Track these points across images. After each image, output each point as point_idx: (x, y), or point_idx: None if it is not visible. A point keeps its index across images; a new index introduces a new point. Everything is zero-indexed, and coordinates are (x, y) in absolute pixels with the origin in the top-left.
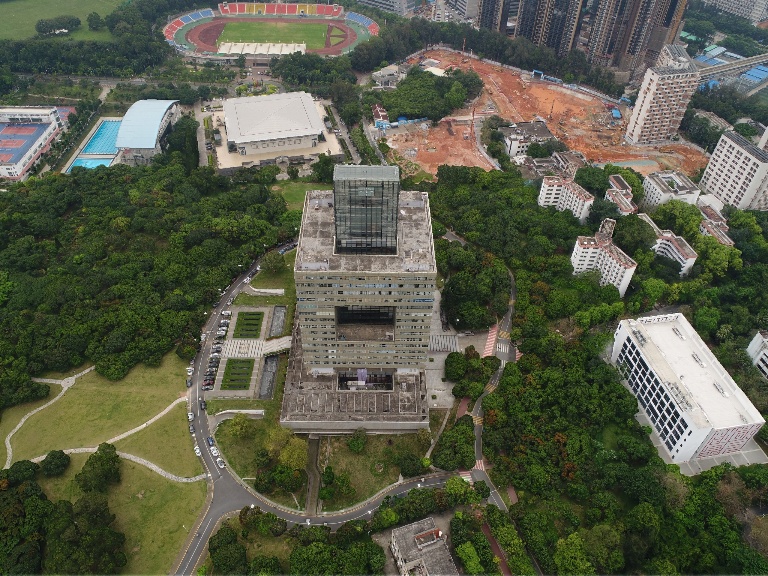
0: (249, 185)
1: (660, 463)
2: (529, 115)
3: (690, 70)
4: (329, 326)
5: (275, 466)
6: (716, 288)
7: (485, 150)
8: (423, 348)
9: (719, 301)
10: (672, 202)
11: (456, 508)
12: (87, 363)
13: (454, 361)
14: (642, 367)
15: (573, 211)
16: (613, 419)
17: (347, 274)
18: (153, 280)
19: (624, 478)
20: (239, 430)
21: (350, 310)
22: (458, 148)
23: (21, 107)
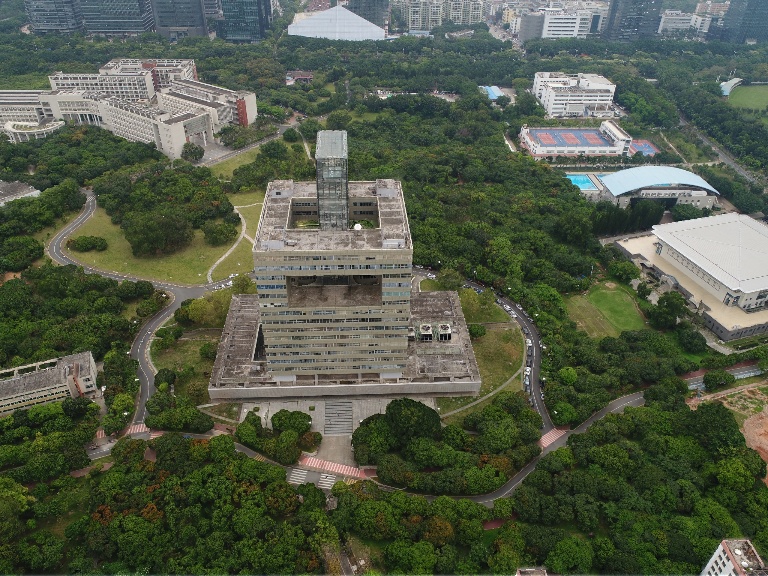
0: (585, 256)
1: None
2: None
3: None
4: None
5: None
6: None
7: None
8: None
9: None
10: None
11: None
12: None
13: (293, 415)
14: None
15: None
16: None
17: None
18: (409, 223)
19: None
20: (234, 280)
21: None
22: None
23: (618, 127)
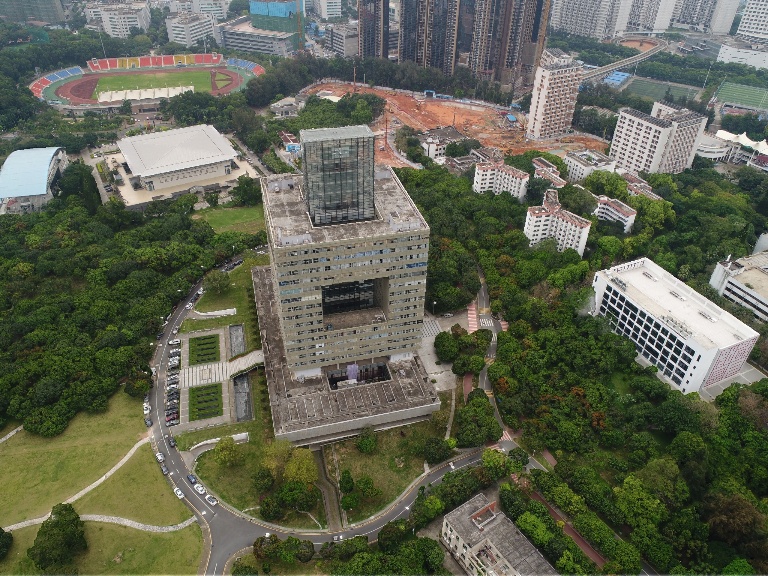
0: (167, 215)
1: (679, 394)
2: (433, 127)
3: (574, 65)
4: (316, 314)
5: (280, 487)
6: (663, 236)
7: (404, 157)
8: (418, 325)
9: (669, 247)
10: (596, 173)
11: (497, 483)
12: (10, 425)
13: (445, 341)
14: (630, 310)
15: (511, 192)
16: (617, 366)
17: (335, 243)
18: (78, 320)
19: (652, 415)
20: (228, 455)
21: (327, 302)
22: (377, 159)
23: None
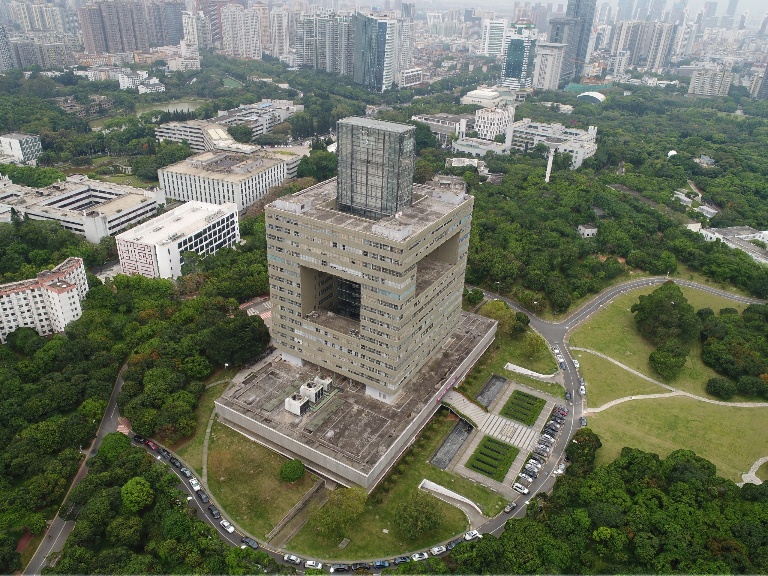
0: None
1: (262, 229)
2: None
3: None
4: None
5: None
6: (32, 252)
7: None
8: None
9: None
10: None
11: None
12: None
13: None
14: None
15: None
16: None
17: None
18: None
19: None
20: None
21: None
22: None
23: None
